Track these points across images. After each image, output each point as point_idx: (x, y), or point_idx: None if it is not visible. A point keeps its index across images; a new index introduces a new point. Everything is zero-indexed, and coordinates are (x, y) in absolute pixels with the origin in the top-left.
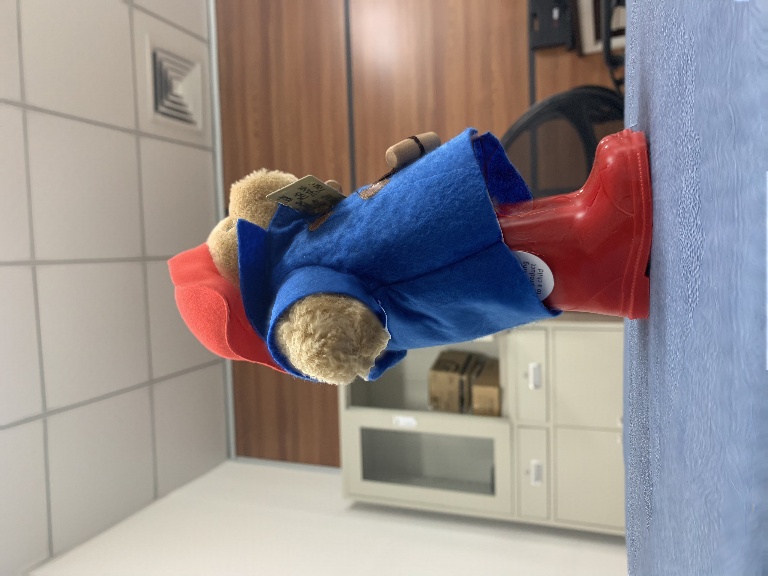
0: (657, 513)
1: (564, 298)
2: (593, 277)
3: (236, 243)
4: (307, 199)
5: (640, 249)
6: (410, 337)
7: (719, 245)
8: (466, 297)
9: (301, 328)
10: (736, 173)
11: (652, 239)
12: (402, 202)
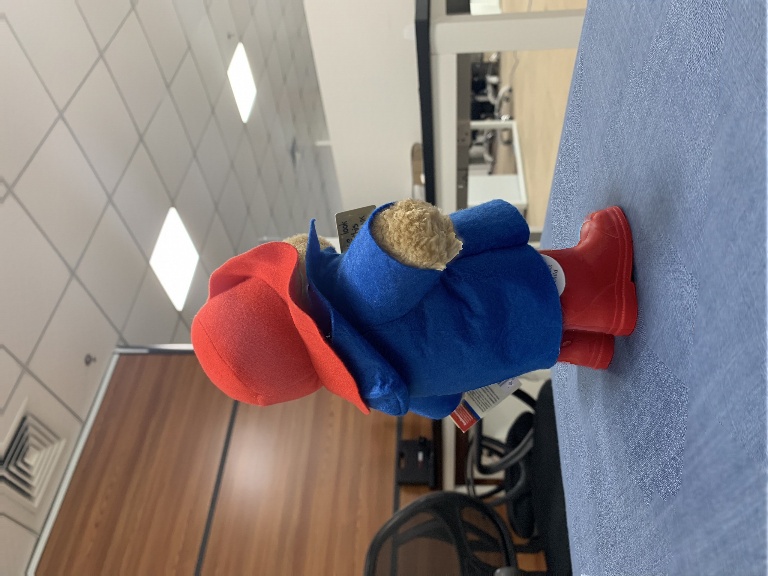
0: (702, 344)
1: (571, 302)
2: (593, 283)
3: None
4: None
5: (625, 260)
6: (443, 326)
7: None
8: (503, 273)
9: (404, 206)
10: None
11: (637, 236)
12: (451, 216)
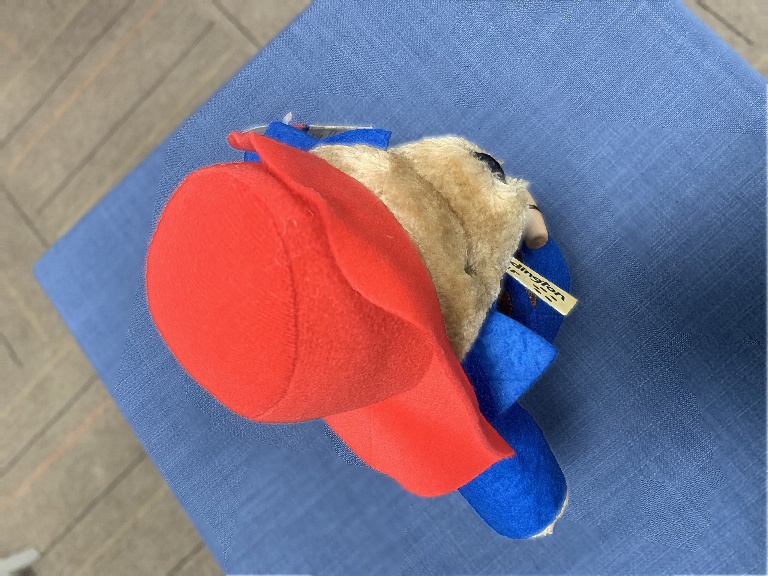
0: (450, 504)
1: None
2: None
3: (481, 322)
4: None
5: None
6: None
7: (716, 570)
8: None
9: None
10: (744, 575)
11: None
12: None
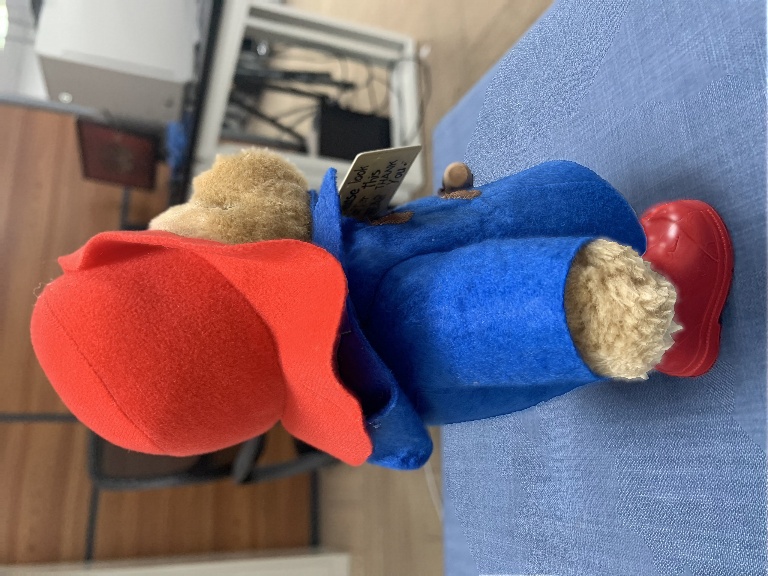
0: None
1: None
2: (682, 321)
3: (262, 222)
4: (367, 190)
5: (720, 294)
6: None
7: None
8: None
9: (626, 271)
10: None
11: (757, 275)
12: (545, 199)
